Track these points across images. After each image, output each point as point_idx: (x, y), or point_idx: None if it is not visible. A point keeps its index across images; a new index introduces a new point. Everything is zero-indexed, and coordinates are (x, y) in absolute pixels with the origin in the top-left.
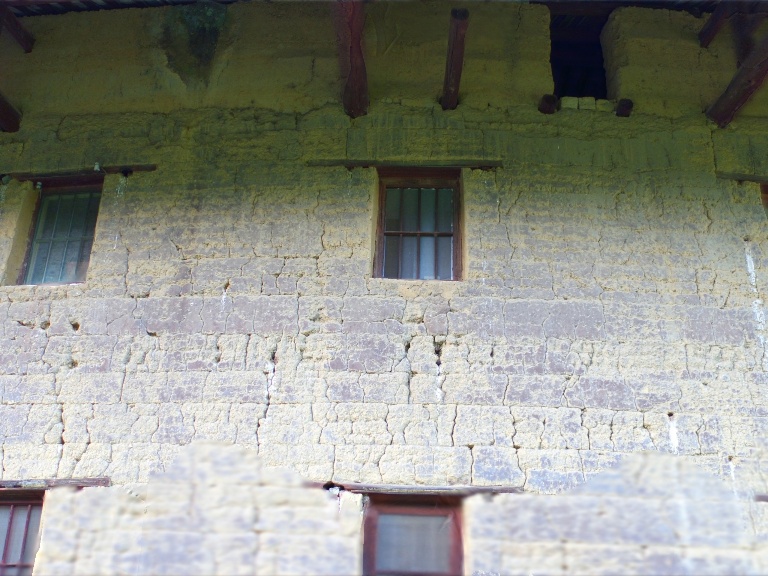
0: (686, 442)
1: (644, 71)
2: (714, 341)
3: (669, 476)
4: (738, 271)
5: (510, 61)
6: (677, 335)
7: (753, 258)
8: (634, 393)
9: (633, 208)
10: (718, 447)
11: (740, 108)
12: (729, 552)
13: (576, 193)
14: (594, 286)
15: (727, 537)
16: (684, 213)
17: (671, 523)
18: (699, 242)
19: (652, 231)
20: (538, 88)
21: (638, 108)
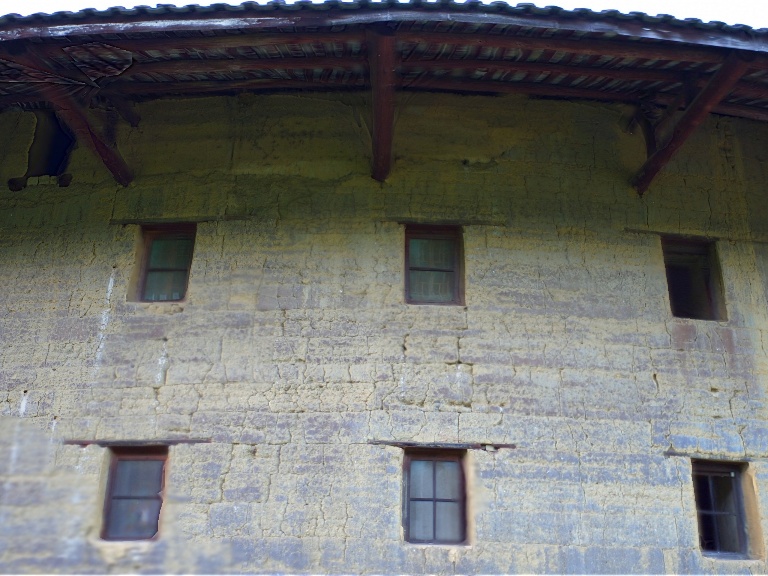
0: (30, 409)
1: (88, 151)
2: (69, 340)
3: (13, 432)
4: (101, 290)
5: (2, 156)
6: (46, 338)
7: (114, 280)
8: (7, 379)
9: (46, 253)
10: (49, 411)
11: (145, 170)
12: (35, 478)
13: (13, 246)
14: (4, 310)
15: (36, 468)
16: (78, 253)
17: (5, 461)
18: (81, 272)
19: (53, 268)
20: (14, 173)
21: (75, 179)
